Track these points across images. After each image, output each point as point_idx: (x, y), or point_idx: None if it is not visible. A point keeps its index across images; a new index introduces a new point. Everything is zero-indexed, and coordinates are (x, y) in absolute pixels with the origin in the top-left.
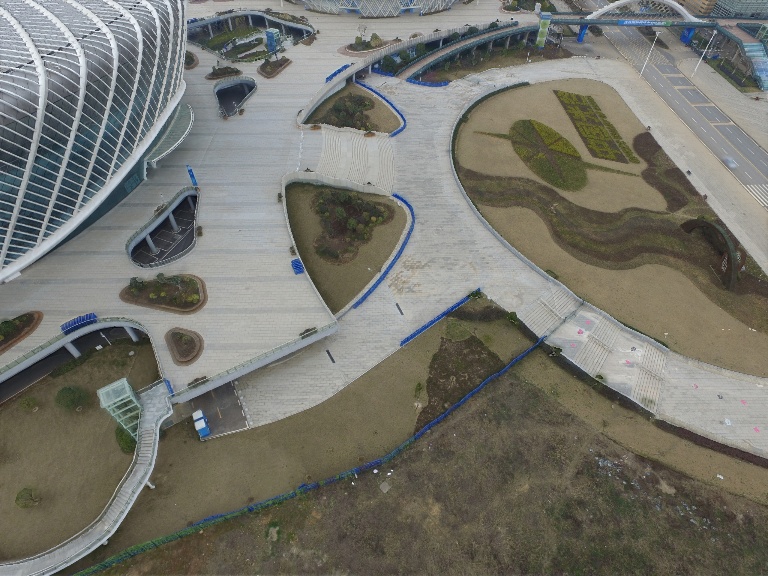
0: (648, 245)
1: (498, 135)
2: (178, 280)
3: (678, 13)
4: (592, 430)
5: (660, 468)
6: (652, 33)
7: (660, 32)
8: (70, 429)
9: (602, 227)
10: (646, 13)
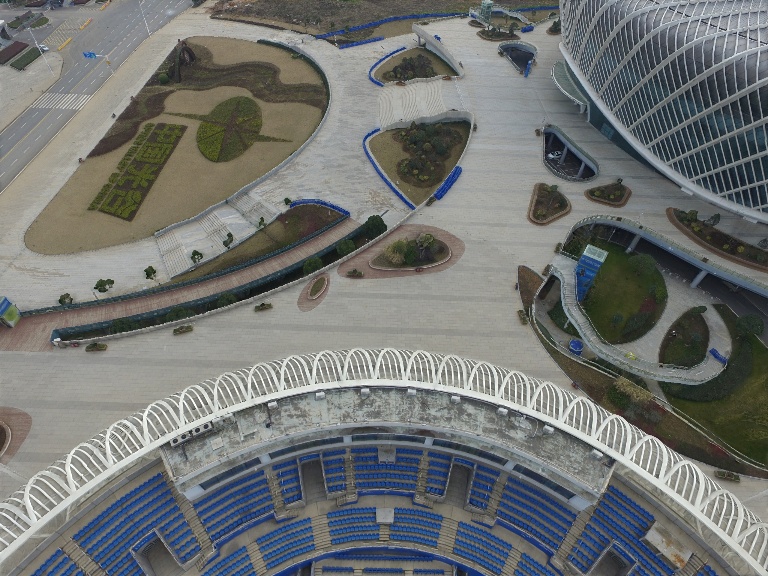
0: (218, 72)
1: (268, 138)
2: None
3: None
4: None
5: None
6: None
7: None
8: None
9: (240, 78)
10: None
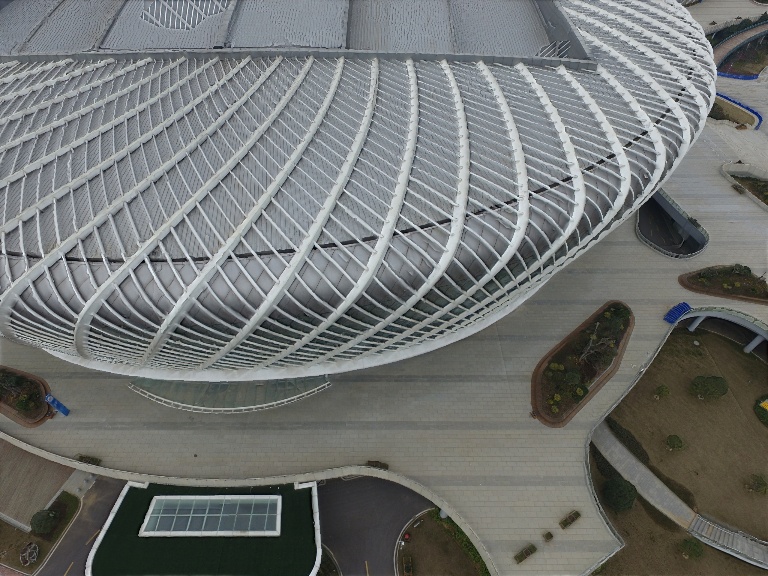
0: None
1: None
2: None
3: None
4: None
5: None
6: None
7: None
8: (711, 417)
9: None
10: None
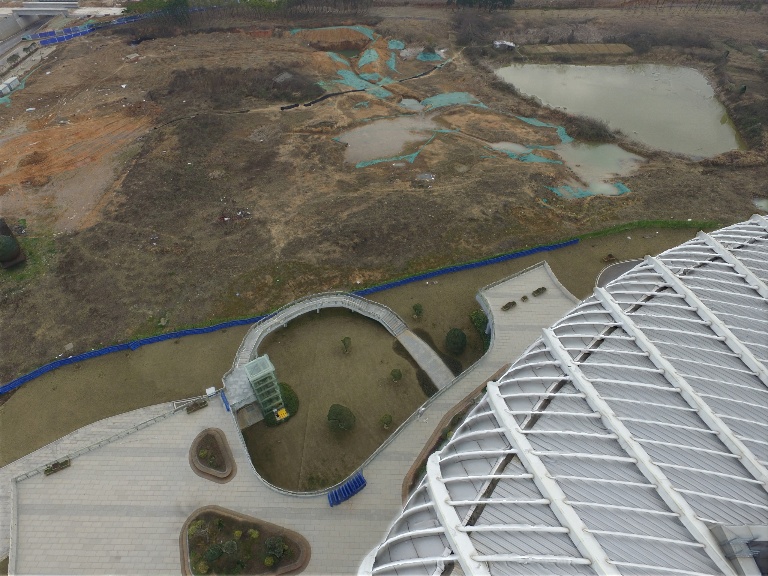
0: None
1: None
2: (209, 550)
3: None
4: None
5: None
6: None
7: None
8: None
9: None
10: None
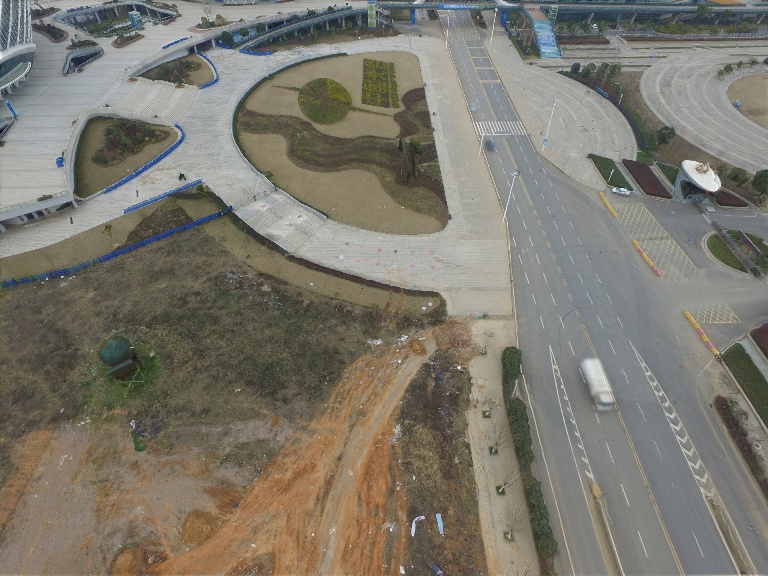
0: (361, 158)
1: (291, 88)
2: None
3: None
4: (237, 260)
5: (270, 279)
6: (479, 17)
7: None
8: None
9: (332, 147)
10: None
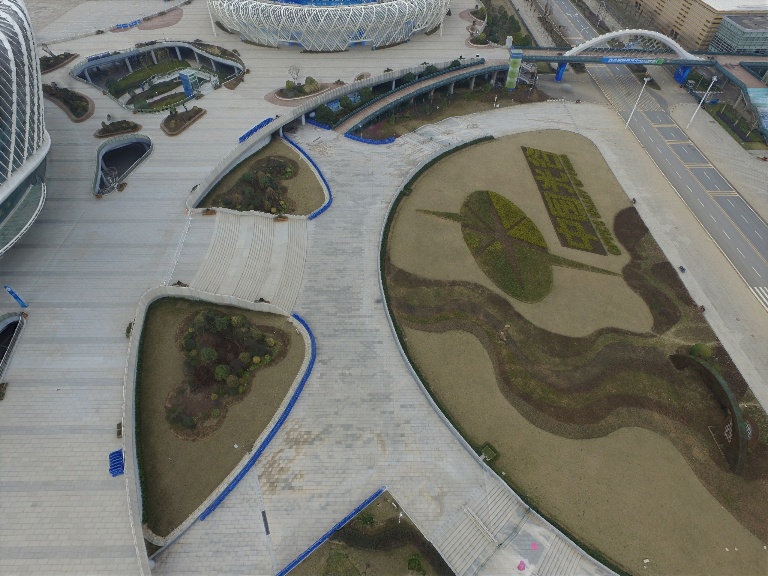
0: (626, 392)
1: (446, 215)
2: None
3: (671, 49)
4: None
5: None
6: (642, 70)
7: (649, 78)
8: None
9: (566, 363)
10: (634, 48)
